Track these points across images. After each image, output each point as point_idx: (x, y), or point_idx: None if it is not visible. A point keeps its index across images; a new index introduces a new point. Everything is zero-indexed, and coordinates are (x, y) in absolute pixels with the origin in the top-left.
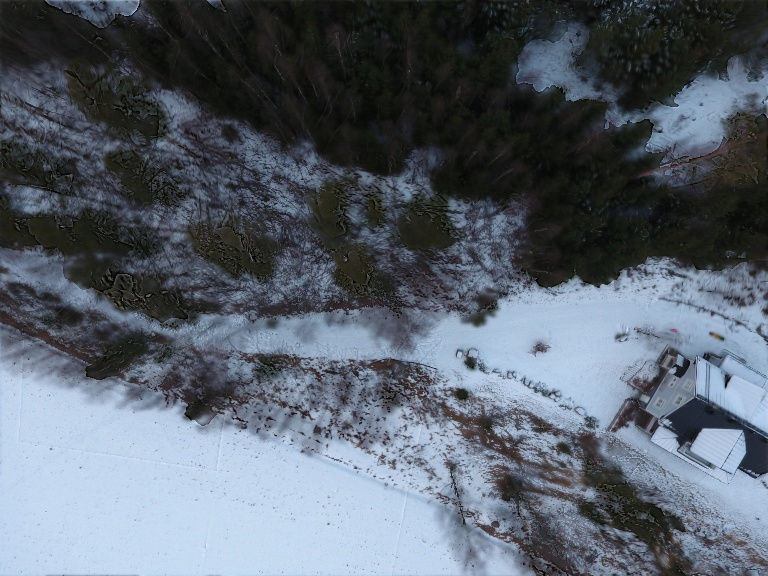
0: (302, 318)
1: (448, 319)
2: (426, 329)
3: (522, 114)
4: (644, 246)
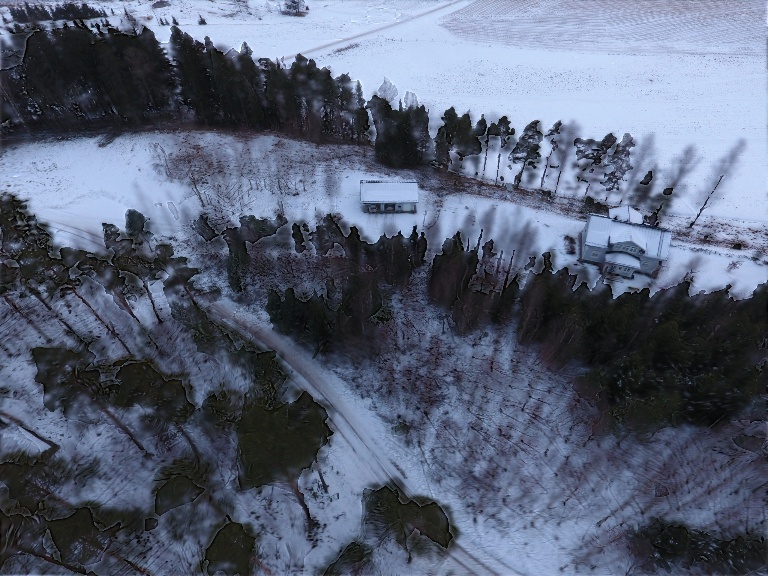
0: None
1: None
2: None
3: None
4: None
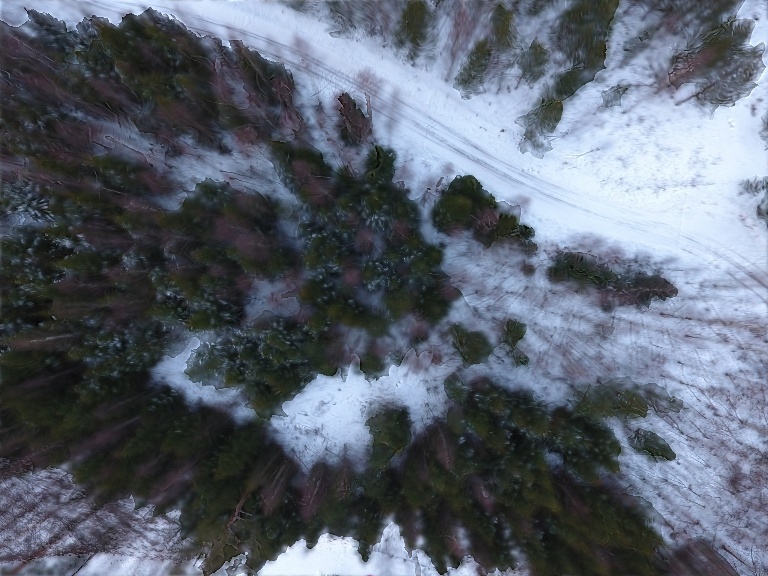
0: (37, 562)
1: (164, 566)
2: (147, 574)
3: (121, 449)
4: (279, 540)
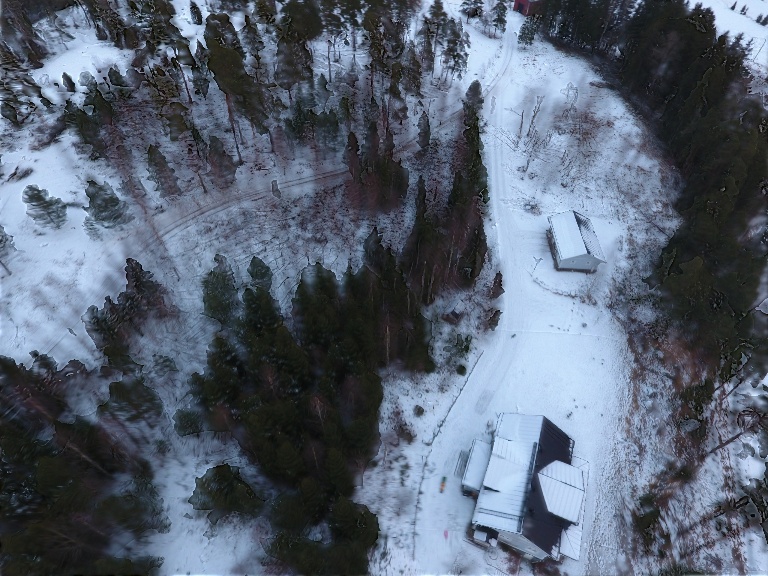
0: None
1: None
2: None
3: None
4: None
